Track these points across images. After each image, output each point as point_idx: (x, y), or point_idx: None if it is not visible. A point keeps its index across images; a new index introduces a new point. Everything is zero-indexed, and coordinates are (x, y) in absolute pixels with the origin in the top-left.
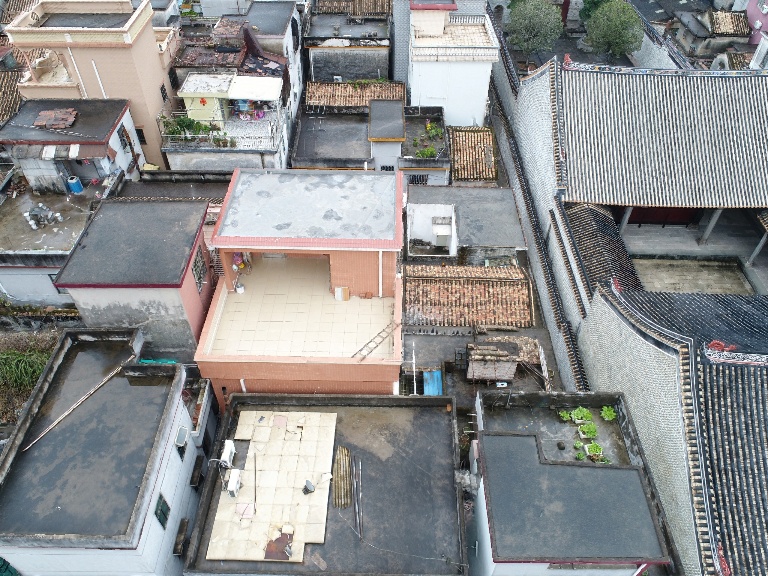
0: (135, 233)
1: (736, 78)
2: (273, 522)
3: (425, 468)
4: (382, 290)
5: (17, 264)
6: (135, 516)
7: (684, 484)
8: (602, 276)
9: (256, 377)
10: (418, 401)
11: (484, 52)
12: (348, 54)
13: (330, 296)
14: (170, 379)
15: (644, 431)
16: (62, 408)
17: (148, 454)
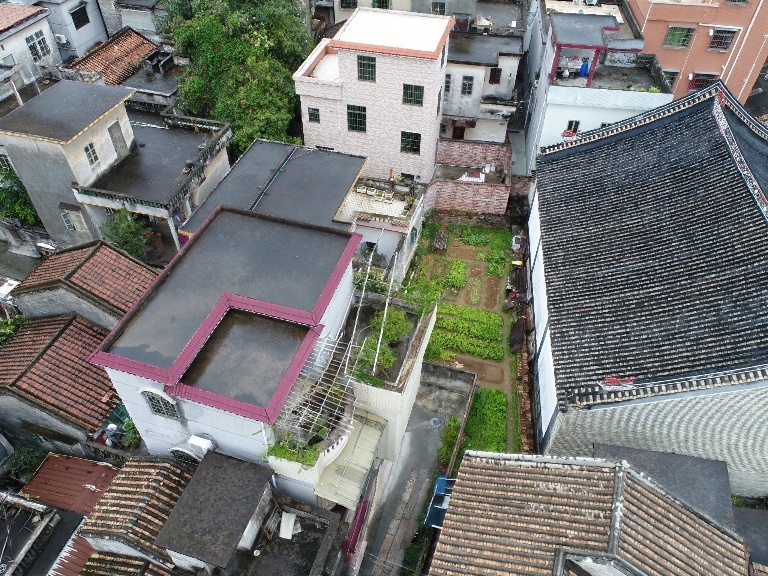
0: None
1: None
2: None
3: None
4: None
5: None
6: None
7: None
8: None
9: None
10: None
11: None
12: None
13: None
14: None
15: None
16: None
17: None
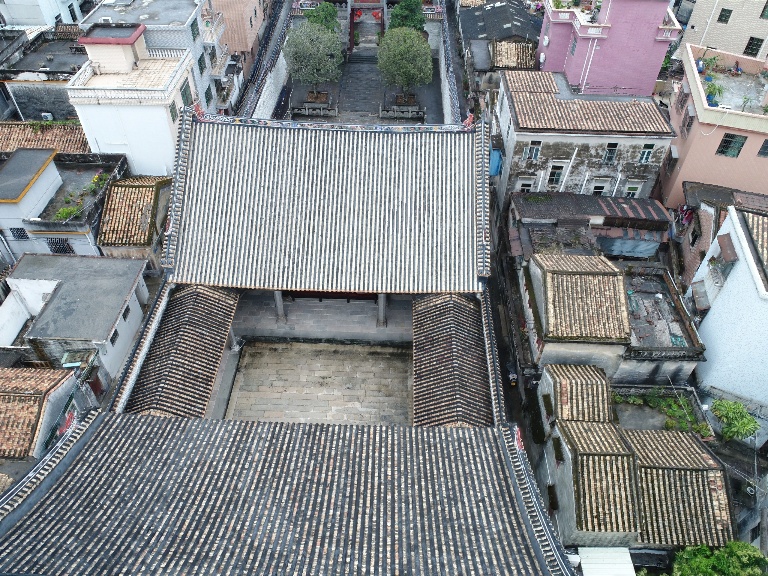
0: None
1: (404, 134)
2: None
3: None
4: None
5: None
6: None
7: None
8: (151, 387)
9: None
10: None
11: (150, 95)
12: (51, 89)
13: None
14: None
15: None
16: None
17: None
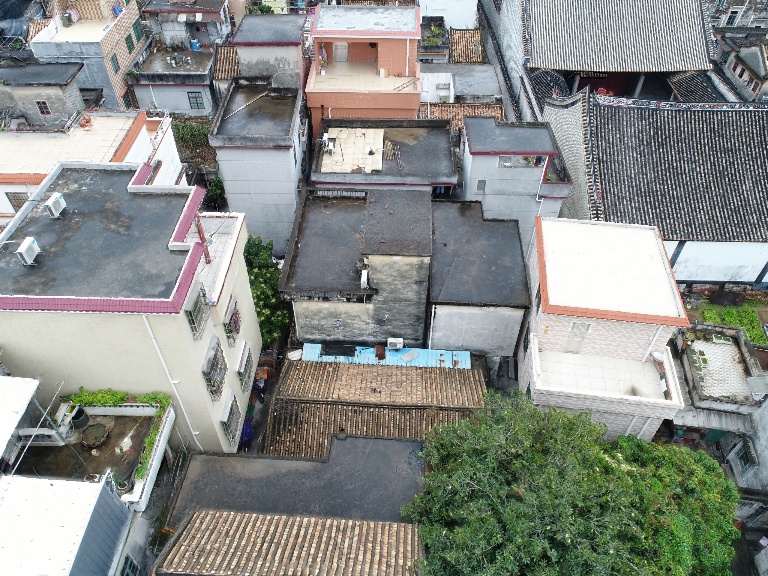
0: (268, 26)
1: None
2: (354, 163)
3: (435, 148)
4: (408, 71)
5: (169, 82)
6: (292, 131)
7: (583, 170)
8: None
9: (338, 106)
10: (430, 123)
11: None
12: None
13: (377, 76)
14: (294, 97)
15: (567, 164)
16: (238, 106)
17: (290, 120)
